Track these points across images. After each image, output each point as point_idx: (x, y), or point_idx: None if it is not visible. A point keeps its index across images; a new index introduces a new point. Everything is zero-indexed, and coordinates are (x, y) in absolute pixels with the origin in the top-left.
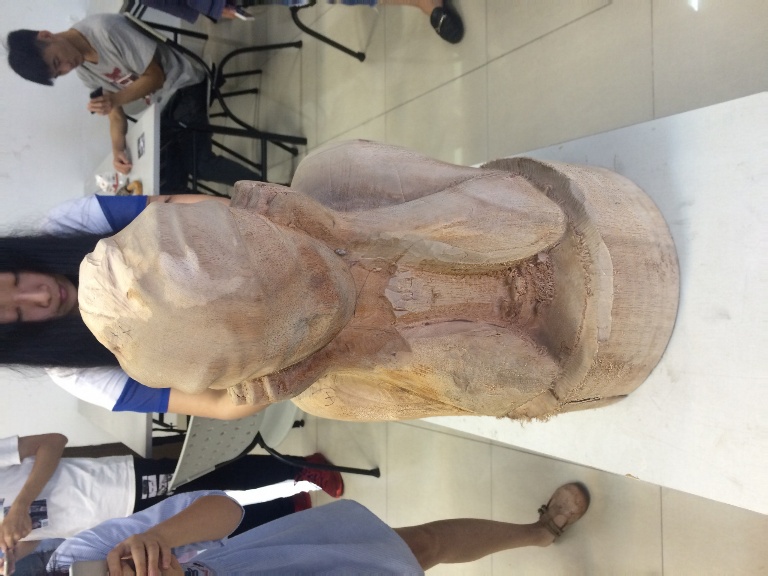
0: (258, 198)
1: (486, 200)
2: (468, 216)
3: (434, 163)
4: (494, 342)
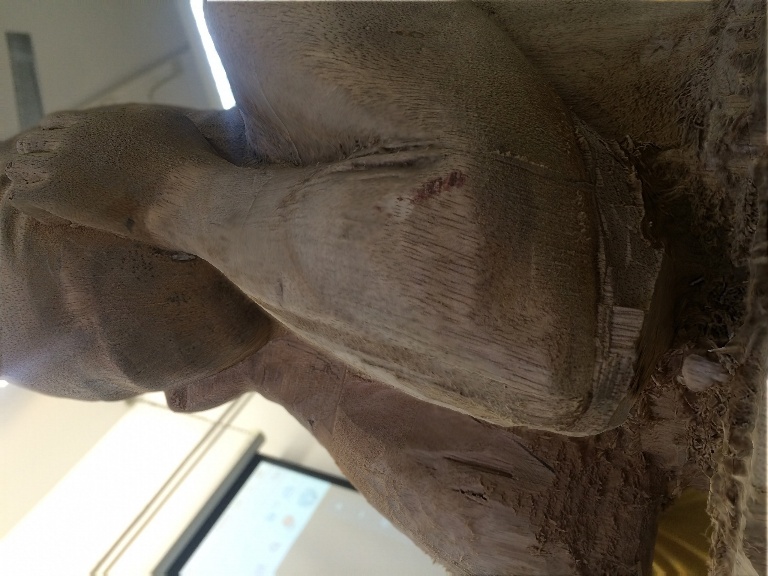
0: None
1: (309, 275)
2: (276, 301)
3: (316, 68)
4: (456, 511)
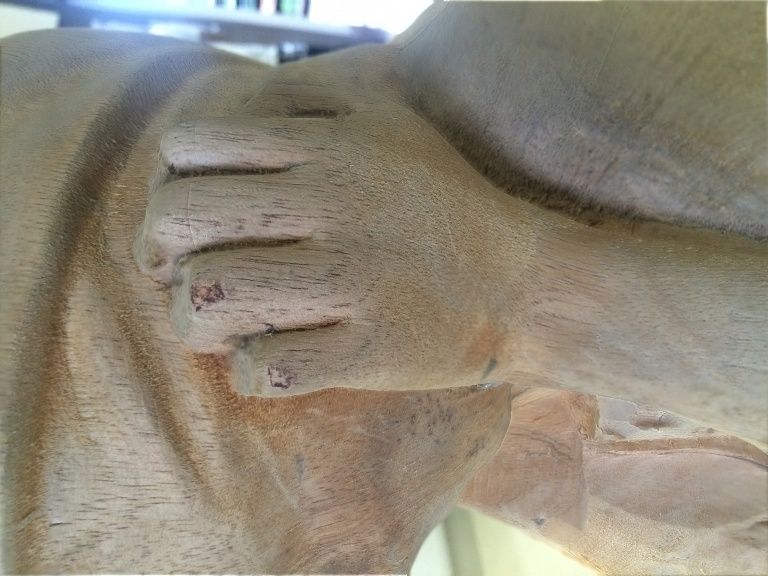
0: (188, 327)
1: None
2: None
3: None
4: None
